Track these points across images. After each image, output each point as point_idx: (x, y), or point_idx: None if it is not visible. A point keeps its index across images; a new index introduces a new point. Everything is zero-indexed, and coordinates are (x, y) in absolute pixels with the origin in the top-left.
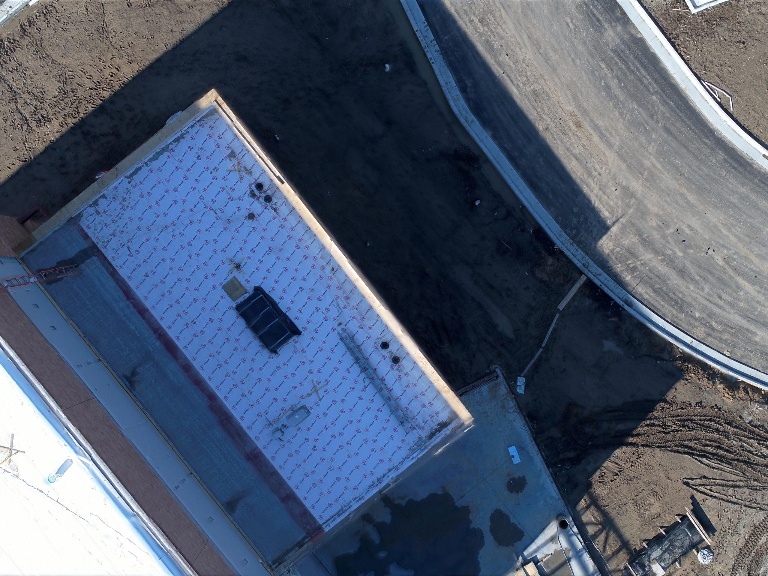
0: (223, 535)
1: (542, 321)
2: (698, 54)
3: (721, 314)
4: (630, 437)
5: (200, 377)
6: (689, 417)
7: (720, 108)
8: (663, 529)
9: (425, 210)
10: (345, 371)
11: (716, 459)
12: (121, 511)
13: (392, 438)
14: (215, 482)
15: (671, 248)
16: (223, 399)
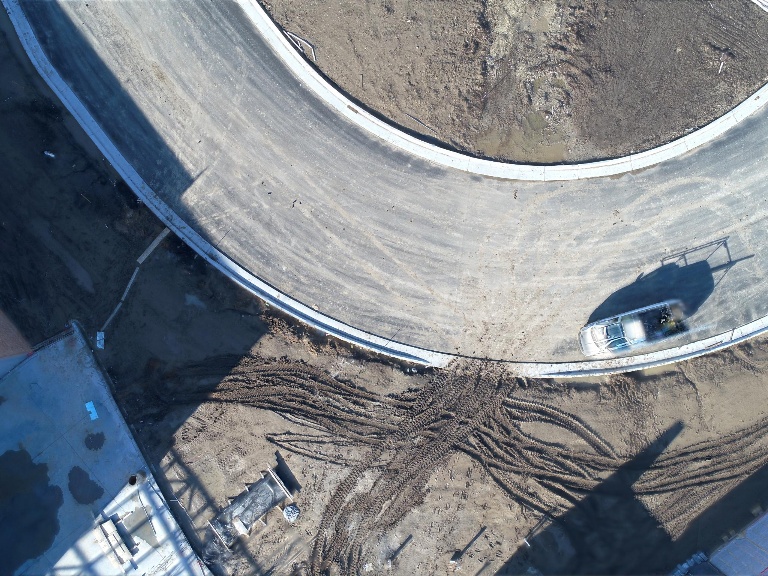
0: None
1: (122, 275)
2: (279, 4)
3: (309, 267)
4: (213, 392)
5: None
6: (274, 372)
7: (302, 58)
8: (248, 486)
9: (0, 162)
10: None
11: (301, 414)
12: None
13: None
14: None
15: (257, 201)
16: None
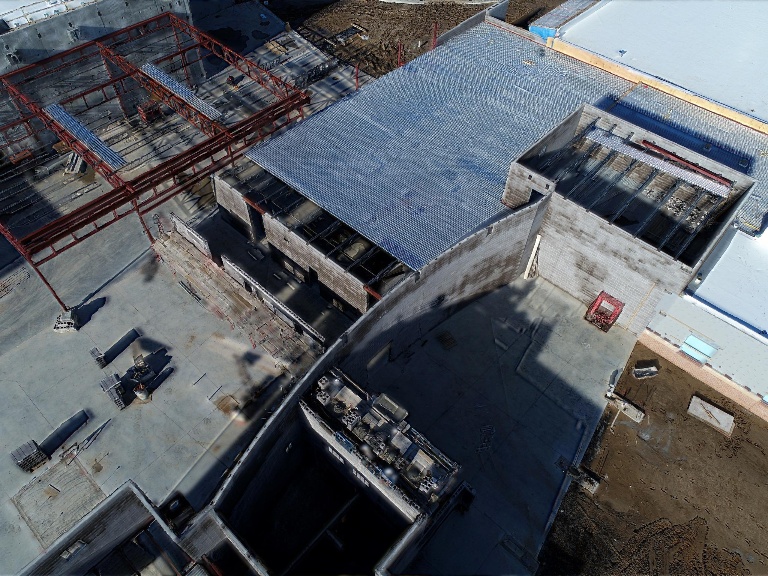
0: None
1: None
2: None
3: None
4: (320, 12)
5: None
6: (348, 6)
7: None
8: None
9: None
10: None
11: None
12: None
13: None
14: None
15: None
16: None
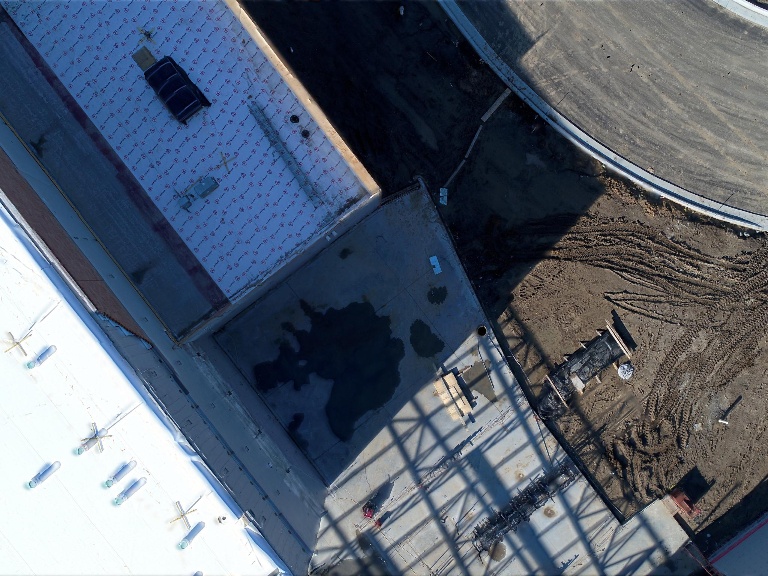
0: (123, 292)
1: (465, 132)
2: None
3: (645, 131)
4: (552, 250)
5: (108, 146)
6: (611, 232)
7: None
8: (584, 344)
9: (350, 19)
10: (254, 144)
11: (637, 274)
12: (3, 220)
13: (301, 213)
14: (121, 252)
15: (596, 64)
16: (131, 169)
